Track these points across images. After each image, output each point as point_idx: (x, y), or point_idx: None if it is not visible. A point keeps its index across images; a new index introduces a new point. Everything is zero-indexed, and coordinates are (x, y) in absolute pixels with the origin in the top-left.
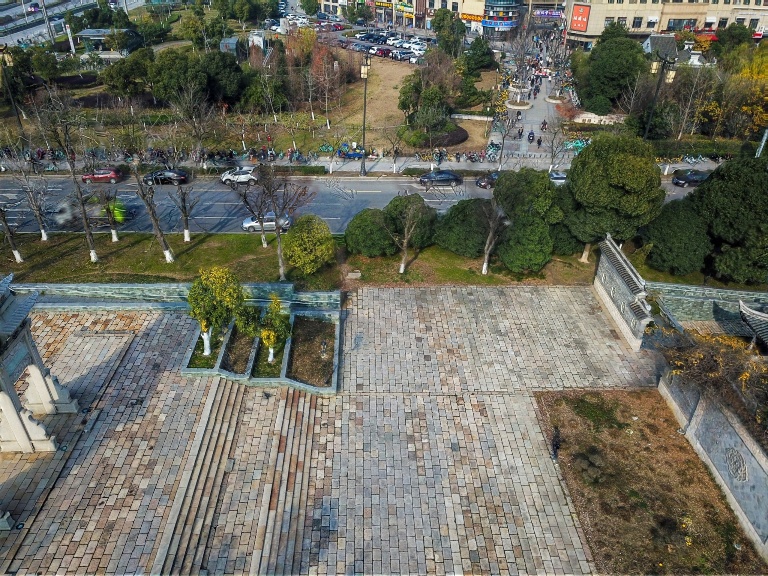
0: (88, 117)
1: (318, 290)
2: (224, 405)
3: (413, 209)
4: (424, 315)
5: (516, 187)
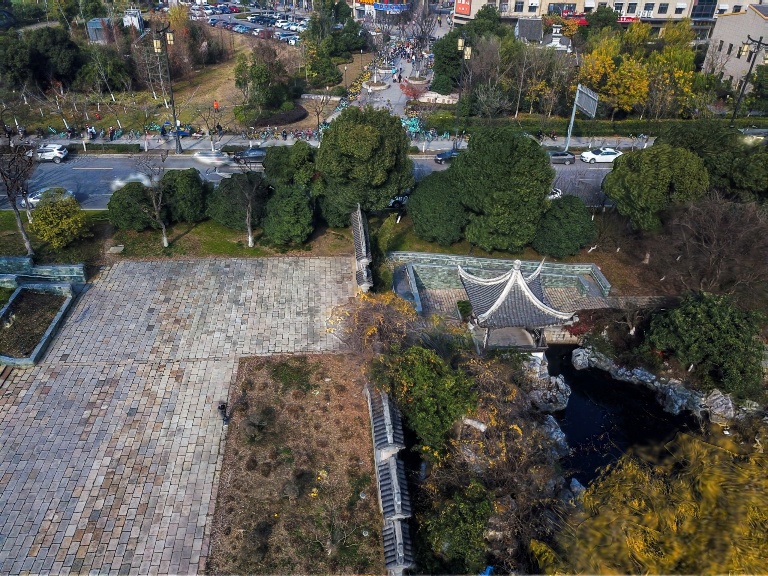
0: None
1: (68, 264)
2: None
3: None
4: (169, 287)
5: (279, 159)
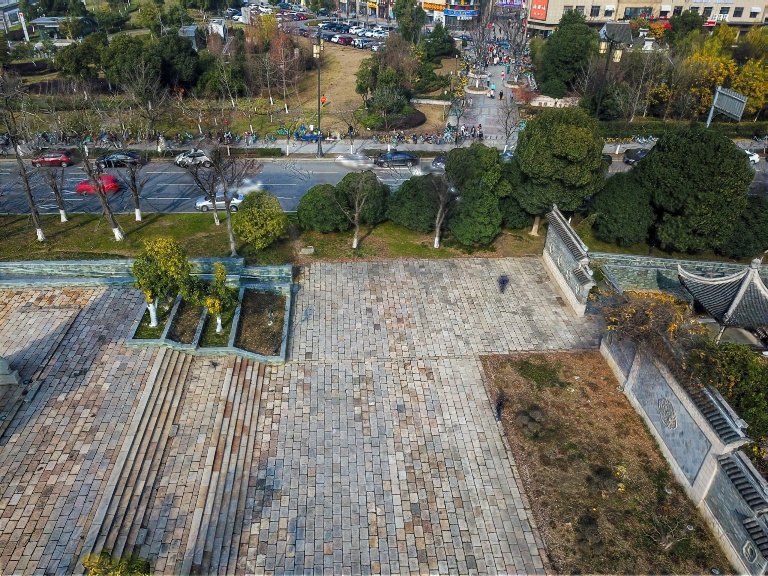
0: (31, 93)
1: (270, 265)
2: (170, 374)
3: (362, 181)
4: (375, 287)
5: (466, 161)
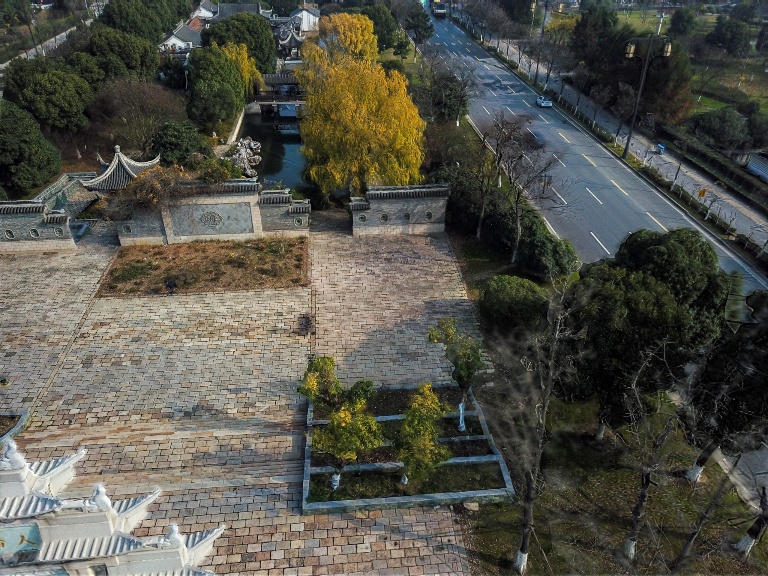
0: None
1: None
2: None
3: None
4: None
5: None
